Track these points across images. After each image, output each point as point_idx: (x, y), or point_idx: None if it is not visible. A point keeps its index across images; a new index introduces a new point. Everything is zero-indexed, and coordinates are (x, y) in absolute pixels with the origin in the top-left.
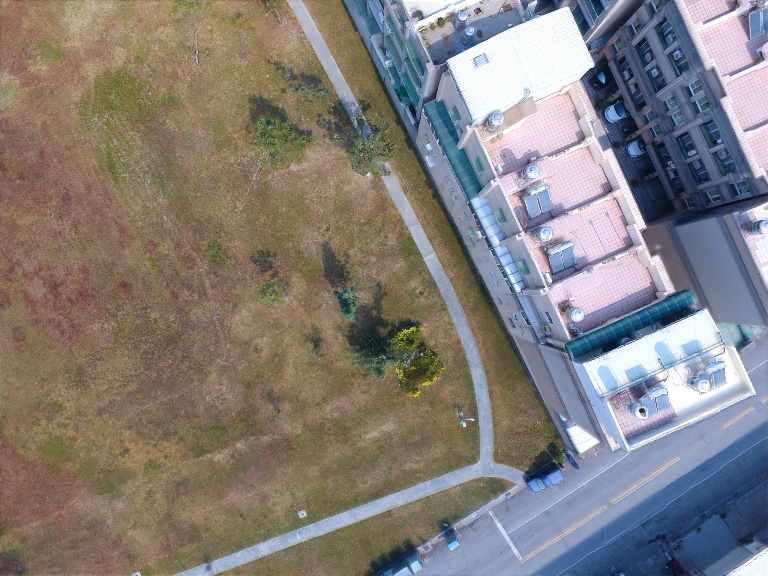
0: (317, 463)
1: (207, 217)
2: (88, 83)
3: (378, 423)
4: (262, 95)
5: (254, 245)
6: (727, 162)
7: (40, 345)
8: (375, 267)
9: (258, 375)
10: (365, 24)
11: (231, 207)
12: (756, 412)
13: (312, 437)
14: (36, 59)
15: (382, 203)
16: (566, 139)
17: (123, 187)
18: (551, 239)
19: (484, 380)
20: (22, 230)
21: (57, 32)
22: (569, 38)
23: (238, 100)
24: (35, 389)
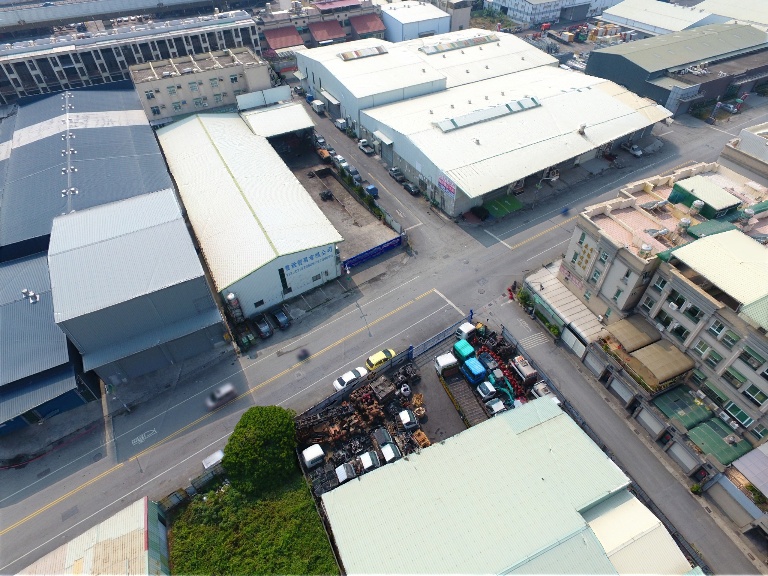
0: None
1: None
2: None
3: None
4: None
5: None
6: None
7: None
8: None
9: None
10: None
11: None
12: None
13: None
14: None
15: None
16: None
17: None
18: None
19: None
20: None
21: None
22: None
23: None
24: None
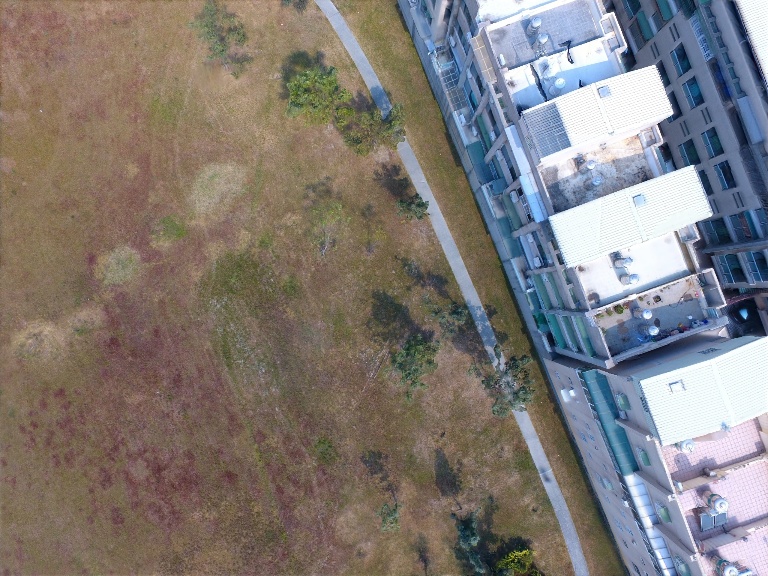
0: None
1: (320, 412)
2: (210, 264)
3: None
4: (386, 291)
5: (366, 445)
6: None
7: (138, 529)
8: (488, 479)
9: None
10: (507, 245)
11: (345, 404)
12: None
13: None
14: (159, 234)
15: None
16: (745, 449)
17: (236, 374)
18: None
19: None
20: (130, 409)
21: (183, 209)
22: None
23: (361, 294)
24: (129, 575)
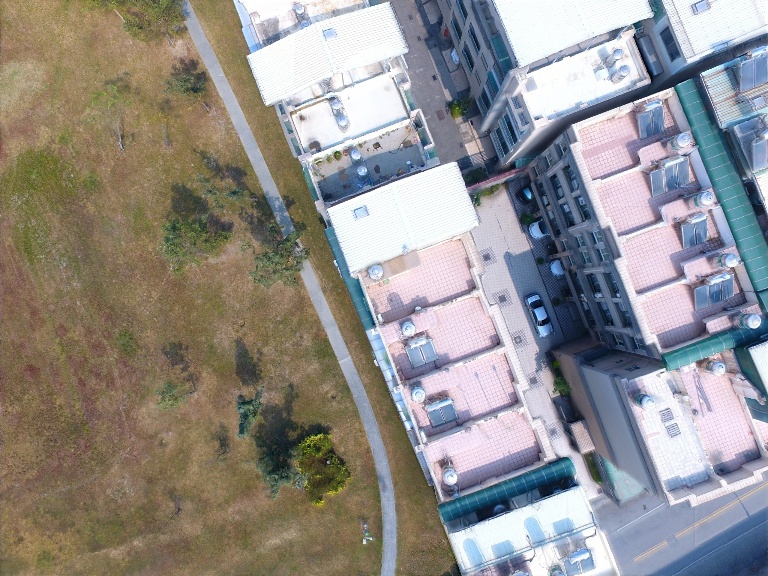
0: (214, 567)
1: (121, 305)
2: (11, 161)
3: (279, 529)
4: (185, 184)
5: (166, 337)
6: (628, 314)
7: None
8: (288, 367)
9: (161, 471)
10: None
11: (146, 296)
12: (669, 546)
13: (211, 539)
14: None
15: (300, 302)
16: (456, 287)
17: (38, 269)
18: (430, 394)
19: (391, 492)
20: None
21: None
22: (454, 195)
23: (161, 188)
24: None
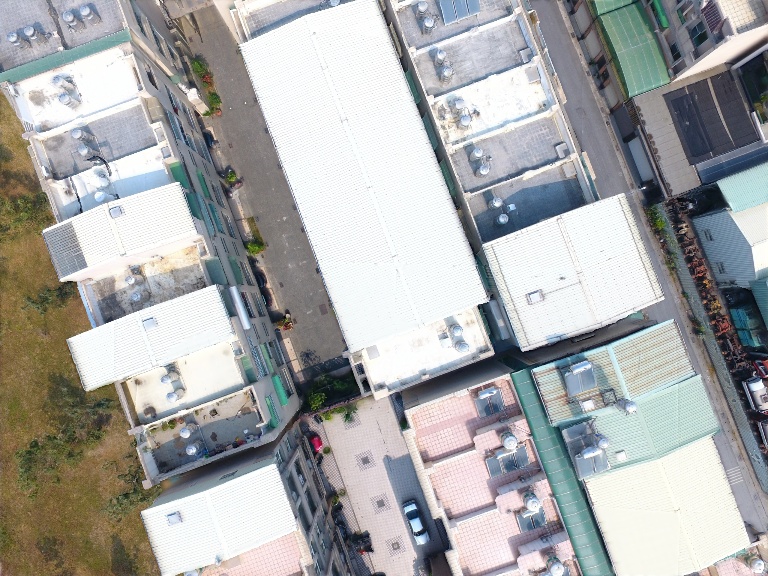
0: None
1: None
2: None
3: None
4: (63, 374)
5: (41, 531)
6: None
7: None
8: None
9: None
10: None
11: None
12: None
13: None
14: None
15: None
16: (288, 569)
17: None
18: None
19: None
20: None
21: None
22: (272, 500)
23: (37, 377)
24: None
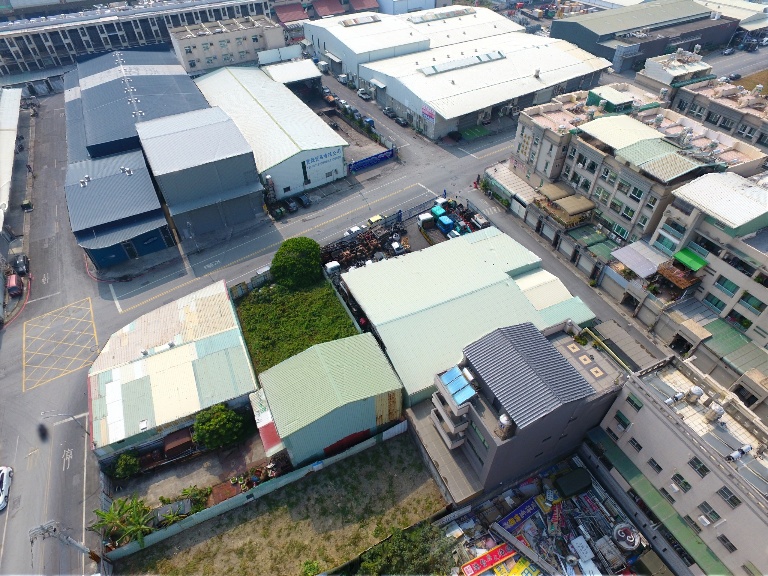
0: None
1: None
2: None
3: None
4: None
5: None
6: None
7: None
8: None
9: None
10: None
11: None
12: None
13: None
14: None
15: None
16: None
17: None
18: None
19: None
20: None
21: None
22: None
23: None
24: None
